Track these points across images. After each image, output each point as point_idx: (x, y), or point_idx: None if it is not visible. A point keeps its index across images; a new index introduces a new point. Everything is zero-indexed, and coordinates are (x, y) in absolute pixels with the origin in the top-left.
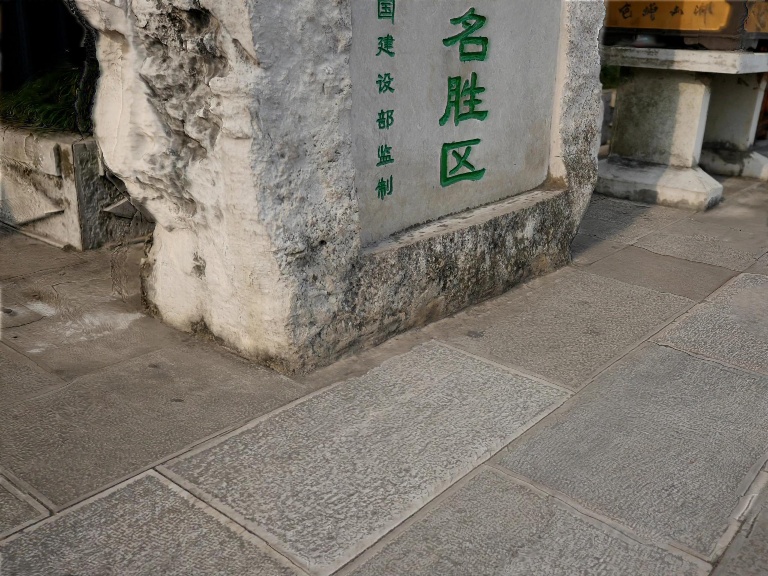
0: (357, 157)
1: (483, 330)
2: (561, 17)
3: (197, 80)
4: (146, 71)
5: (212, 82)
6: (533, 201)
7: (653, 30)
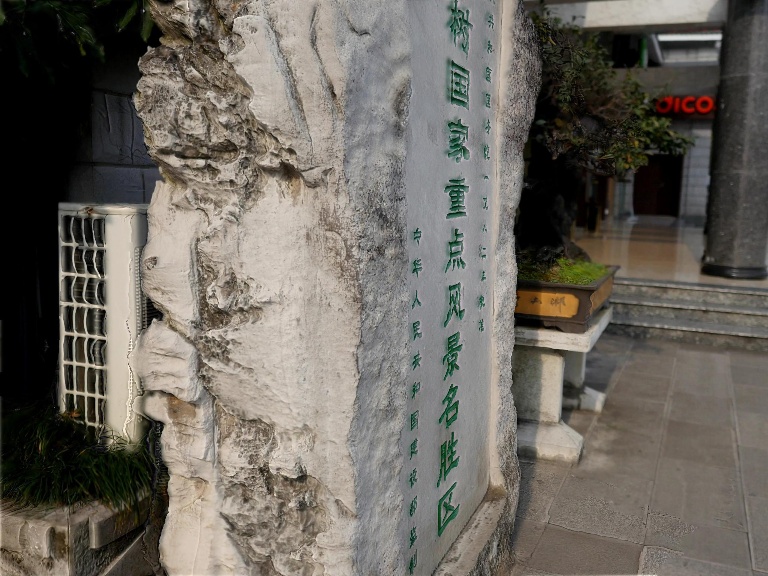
0: None
1: None
2: (492, 357)
3: (283, 519)
4: (228, 510)
5: (319, 538)
6: (493, 520)
7: (518, 314)
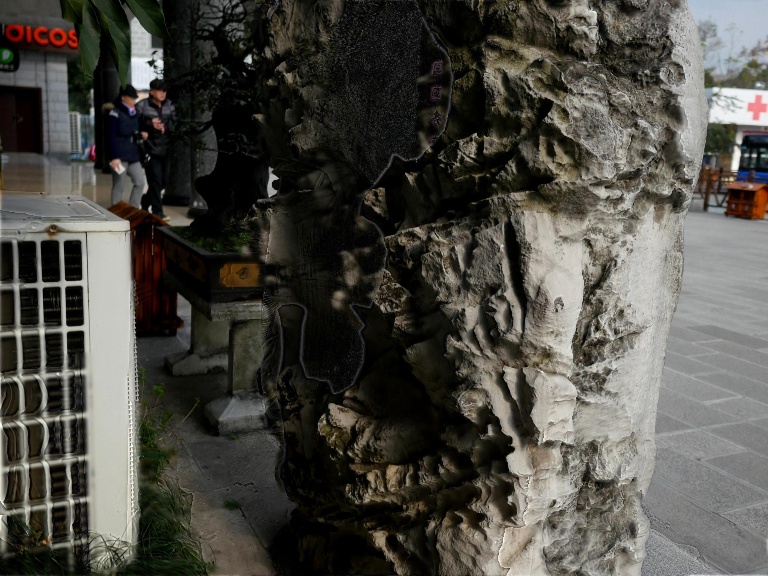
0: None
1: None
2: None
3: None
4: (549, 542)
5: None
6: None
7: None
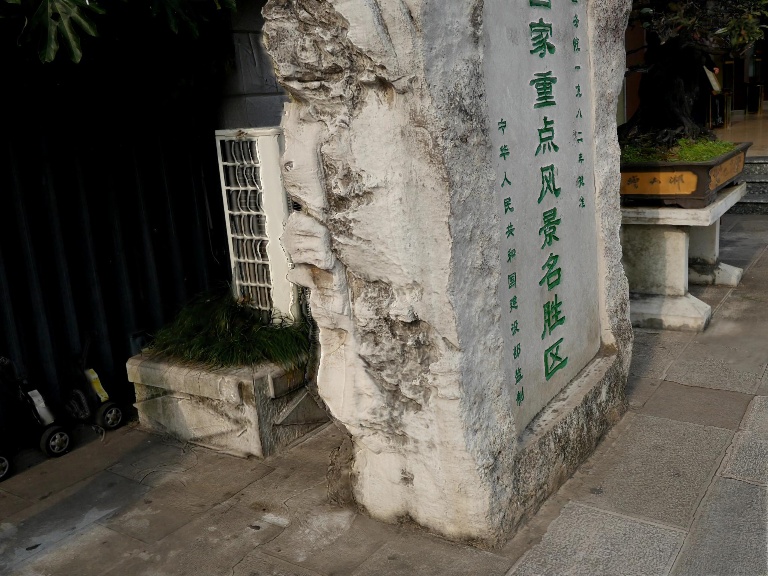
0: None
1: (600, 486)
2: (597, 231)
3: (406, 357)
4: (364, 353)
5: (431, 366)
6: (602, 372)
7: (638, 195)
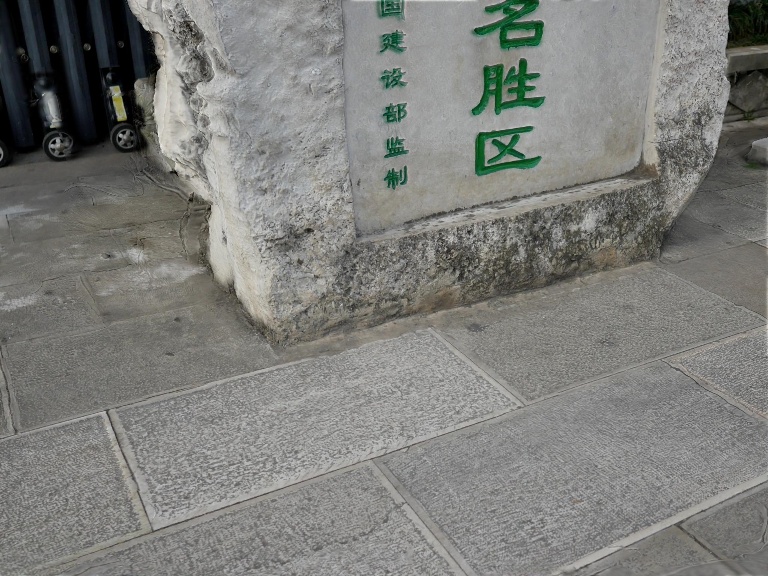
0: (359, 150)
1: (488, 325)
2: None
3: None
4: (179, 68)
5: (198, 86)
6: (599, 192)
7: None
